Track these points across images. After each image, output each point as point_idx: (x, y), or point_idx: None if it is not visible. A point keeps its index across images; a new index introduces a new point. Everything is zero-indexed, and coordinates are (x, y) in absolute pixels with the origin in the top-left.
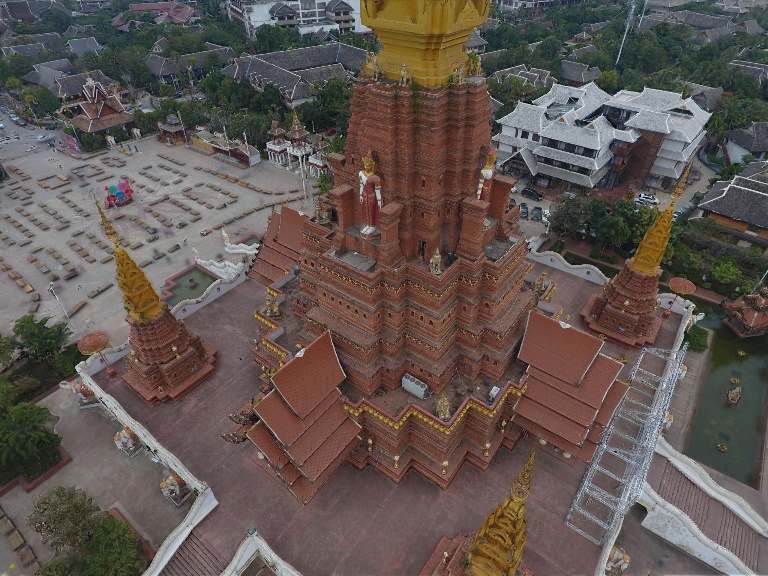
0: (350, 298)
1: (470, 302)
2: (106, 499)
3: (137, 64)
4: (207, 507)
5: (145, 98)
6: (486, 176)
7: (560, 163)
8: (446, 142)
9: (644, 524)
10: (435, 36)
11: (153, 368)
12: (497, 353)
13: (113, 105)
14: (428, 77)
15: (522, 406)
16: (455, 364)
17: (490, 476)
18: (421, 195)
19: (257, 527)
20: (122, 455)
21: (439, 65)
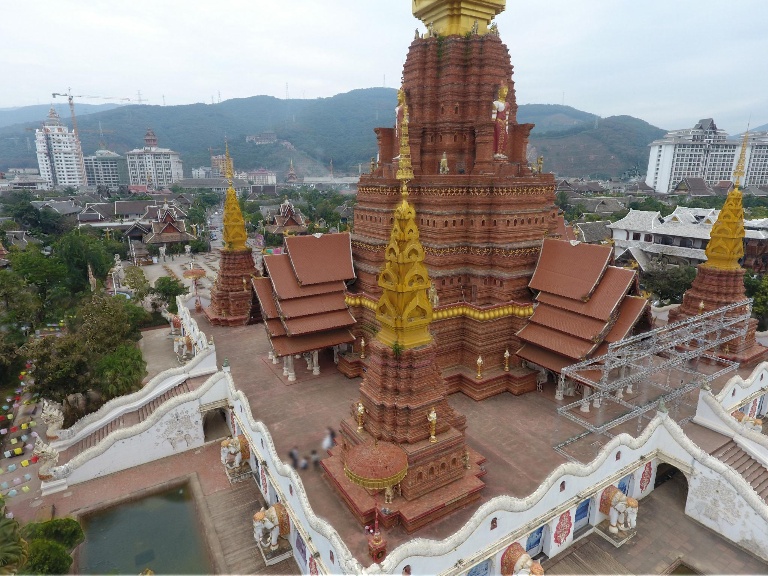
0: (373, 208)
1: (475, 211)
2: (146, 378)
3: (326, 210)
4: (207, 368)
5: (321, 223)
6: (498, 108)
7: (676, 261)
8: (463, 79)
9: (688, 510)
10: (454, 0)
11: (224, 294)
12: (504, 274)
13: (296, 220)
14: (450, 31)
15: (526, 331)
16: (461, 285)
17: (481, 405)
18: (440, 120)
19: (236, 388)
20: (175, 362)
21: (460, 25)
